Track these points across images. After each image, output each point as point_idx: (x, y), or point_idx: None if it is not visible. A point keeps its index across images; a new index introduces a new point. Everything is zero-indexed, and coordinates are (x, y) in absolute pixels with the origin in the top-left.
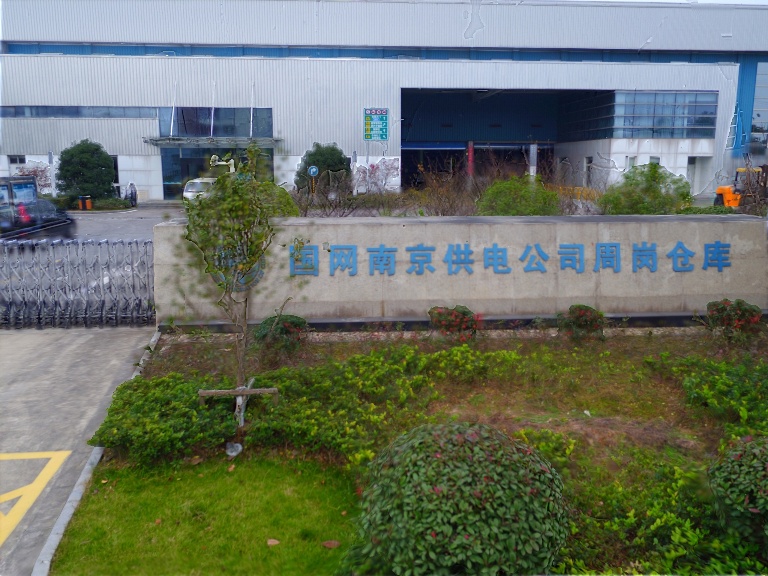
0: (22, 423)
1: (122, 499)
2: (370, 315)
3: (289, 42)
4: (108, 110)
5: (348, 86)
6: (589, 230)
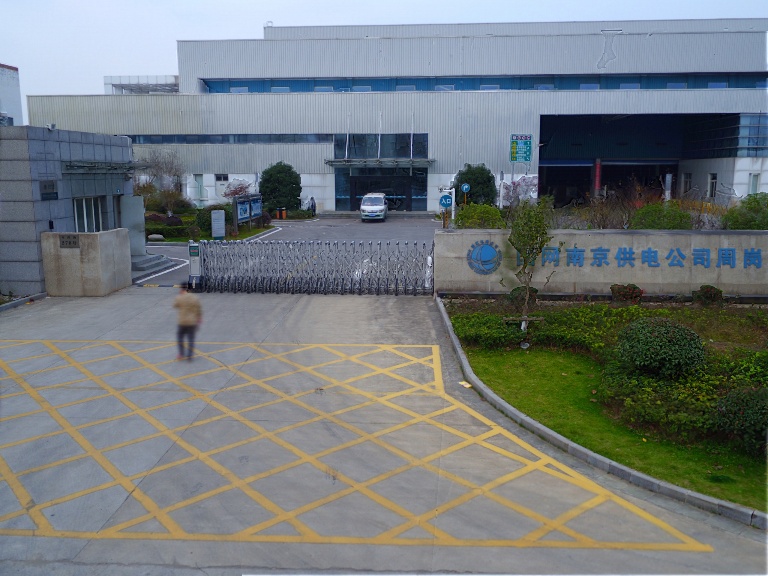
0: None
1: (485, 359)
2: (566, 291)
3: (437, 73)
4: (294, 137)
5: (494, 114)
6: (714, 240)
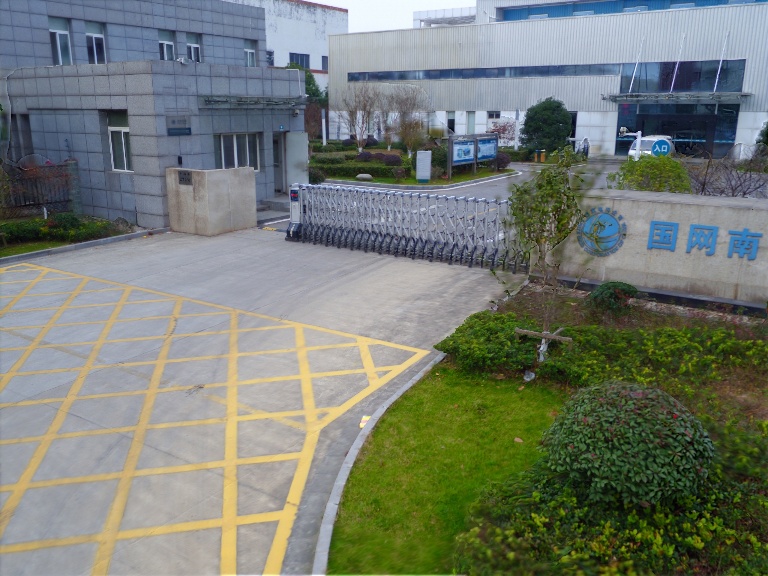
0: (411, 327)
1: (442, 387)
2: (721, 296)
3: None
4: (575, 68)
5: None
6: None
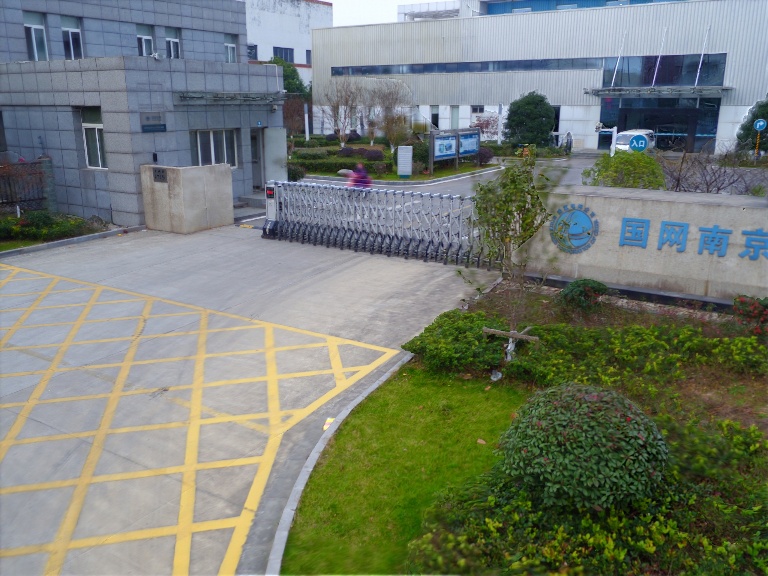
0: (382, 326)
1: (408, 388)
2: (692, 292)
3: None
4: (558, 62)
5: None
6: None
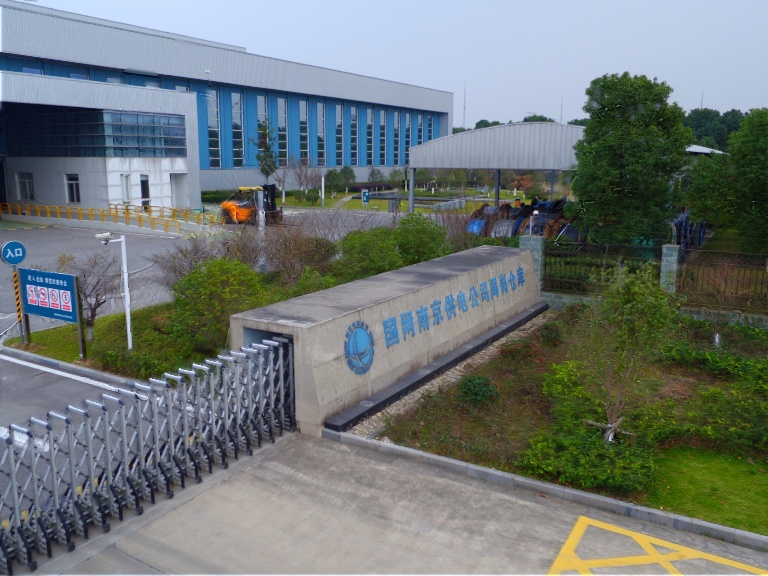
0: (505, 526)
1: None
2: (423, 365)
3: None
4: None
5: None
6: (486, 271)
